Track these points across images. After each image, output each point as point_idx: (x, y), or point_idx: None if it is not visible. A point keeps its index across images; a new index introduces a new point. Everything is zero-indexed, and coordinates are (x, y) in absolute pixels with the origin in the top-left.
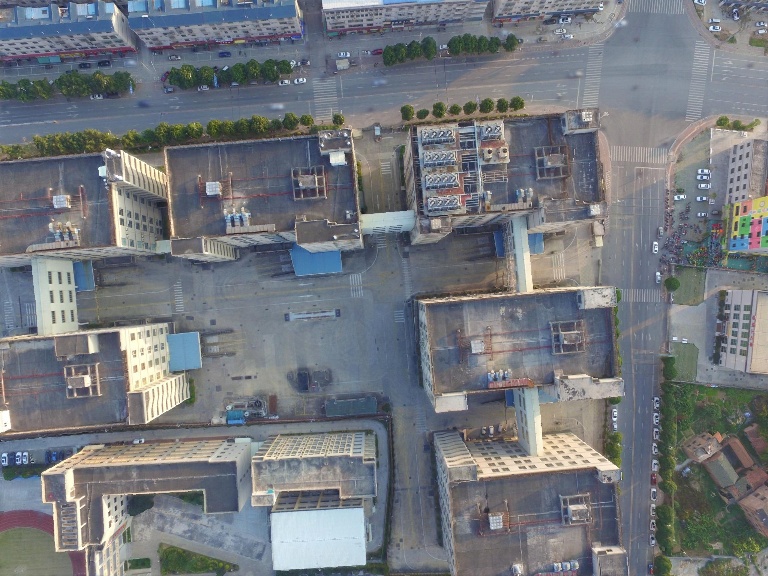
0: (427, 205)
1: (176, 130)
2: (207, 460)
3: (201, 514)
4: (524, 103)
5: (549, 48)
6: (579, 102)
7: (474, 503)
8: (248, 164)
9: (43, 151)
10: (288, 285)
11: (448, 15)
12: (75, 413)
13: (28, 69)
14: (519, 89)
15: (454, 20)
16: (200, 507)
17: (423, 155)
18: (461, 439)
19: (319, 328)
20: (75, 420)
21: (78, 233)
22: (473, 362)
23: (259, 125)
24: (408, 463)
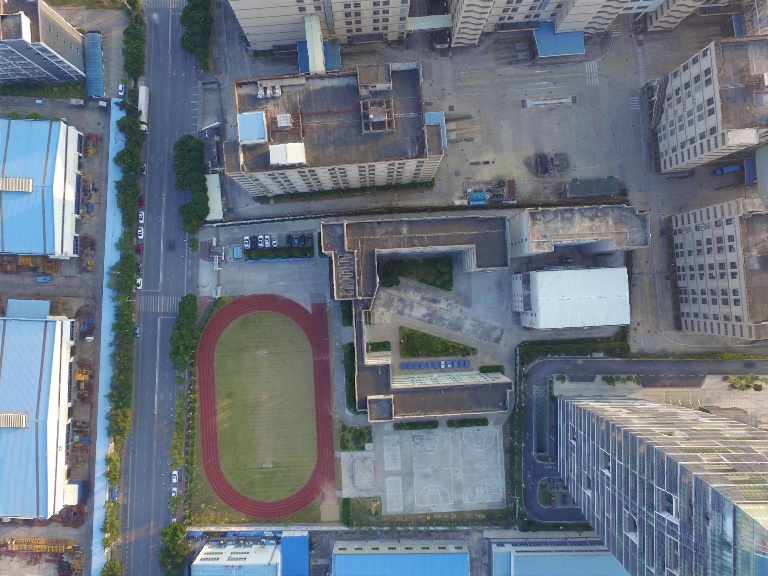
0: None
1: None
2: (478, 215)
3: (440, 298)
4: None
5: None
6: None
7: (761, 239)
8: None
9: None
10: (525, 72)
11: None
12: (368, 150)
13: None
14: None
15: None
16: (439, 291)
17: None
18: None
19: (556, 114)
20: (368, 156)
21: None
22: (759, 101)
23: None
24: (644, 248)
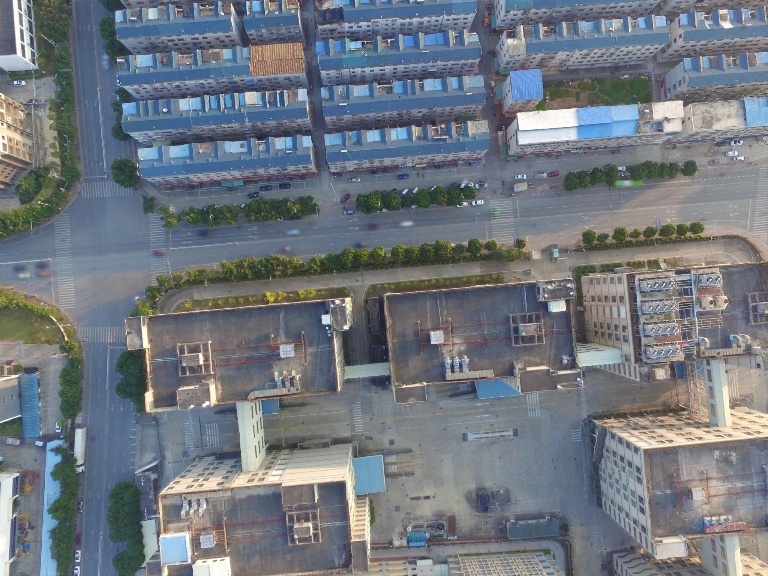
0: (646, 352)
1: (364, 256)
2: None
3: None
4: (703, 228)
5: (721, 169)
6: (750, 222)
7: None
8: (466, 310)
9: (231, 277)
10: (466, 405)
11: (630, 143)
12: (294, 559)
13: (210, 191)
14: (692, 210)
15: (632, 145)
16: None
17: (641, 303)
18: (649, 565)
19: (497, 448)
20: (294, 566)
21: (298, 379)
22: (688, 506)
23: (446, 252)
24: None
